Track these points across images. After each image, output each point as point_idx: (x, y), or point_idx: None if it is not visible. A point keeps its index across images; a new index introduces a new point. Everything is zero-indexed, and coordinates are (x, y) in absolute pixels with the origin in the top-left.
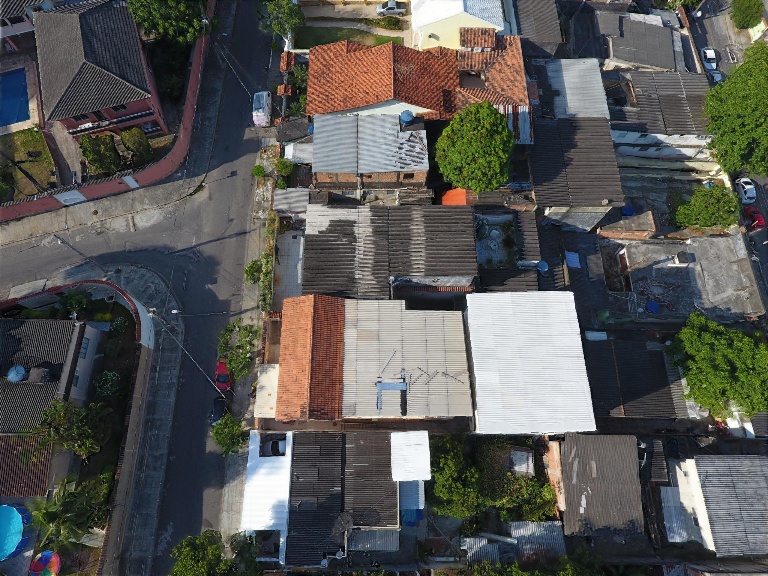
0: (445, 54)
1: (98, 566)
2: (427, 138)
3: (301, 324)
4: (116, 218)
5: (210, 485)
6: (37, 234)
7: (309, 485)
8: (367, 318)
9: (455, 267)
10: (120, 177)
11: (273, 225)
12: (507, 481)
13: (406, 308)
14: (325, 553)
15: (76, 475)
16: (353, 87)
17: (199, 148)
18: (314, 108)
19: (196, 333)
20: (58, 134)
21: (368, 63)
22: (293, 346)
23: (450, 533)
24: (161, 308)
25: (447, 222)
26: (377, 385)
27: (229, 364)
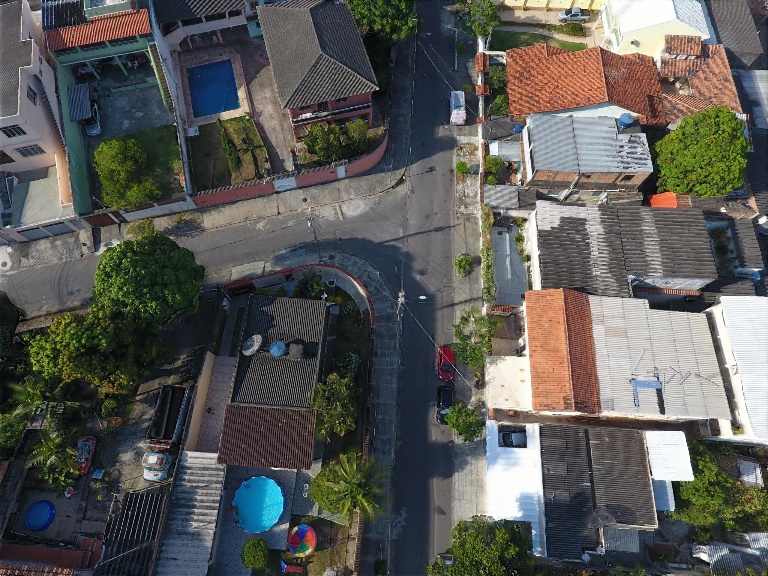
0: (643, 61)
1: (356, 543)
2: (647, 141)
3: (551, 317)
4: (324, 206)
5: (439, 473)
6: (252, 218)
7: (560, 478)
8: (613, 315)
9: (694, 269)
10: (337, 166)
11: (488, 220)
12: (737, 490)
13: (650, 307)
14: (583, 548)
15: (321, 452)
16: (559, 89)
17: (397, 143)
18: (518, 108)
19: (412, 322)
20: (266, 123)
21: (573, 66)
22: (544, 338)
23: (678, 539)
24: (376, 295)
25: (679, 224)
26: (632, 382)
27: (473, 352)
